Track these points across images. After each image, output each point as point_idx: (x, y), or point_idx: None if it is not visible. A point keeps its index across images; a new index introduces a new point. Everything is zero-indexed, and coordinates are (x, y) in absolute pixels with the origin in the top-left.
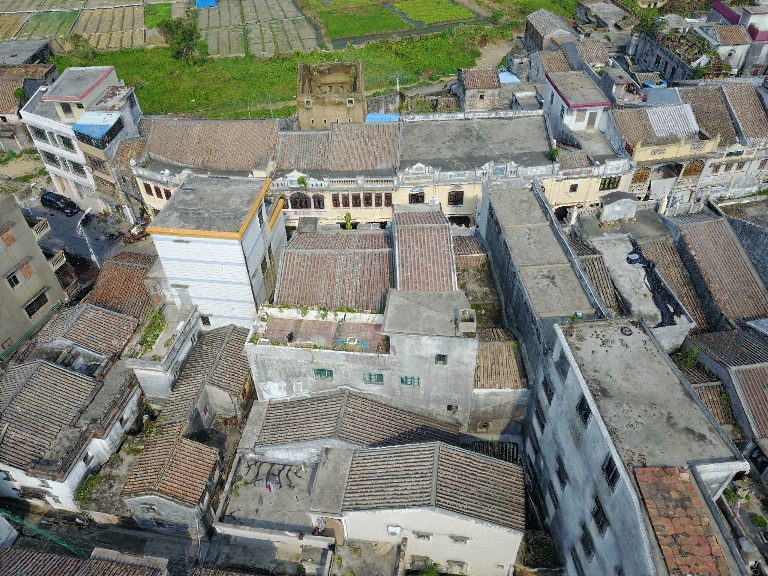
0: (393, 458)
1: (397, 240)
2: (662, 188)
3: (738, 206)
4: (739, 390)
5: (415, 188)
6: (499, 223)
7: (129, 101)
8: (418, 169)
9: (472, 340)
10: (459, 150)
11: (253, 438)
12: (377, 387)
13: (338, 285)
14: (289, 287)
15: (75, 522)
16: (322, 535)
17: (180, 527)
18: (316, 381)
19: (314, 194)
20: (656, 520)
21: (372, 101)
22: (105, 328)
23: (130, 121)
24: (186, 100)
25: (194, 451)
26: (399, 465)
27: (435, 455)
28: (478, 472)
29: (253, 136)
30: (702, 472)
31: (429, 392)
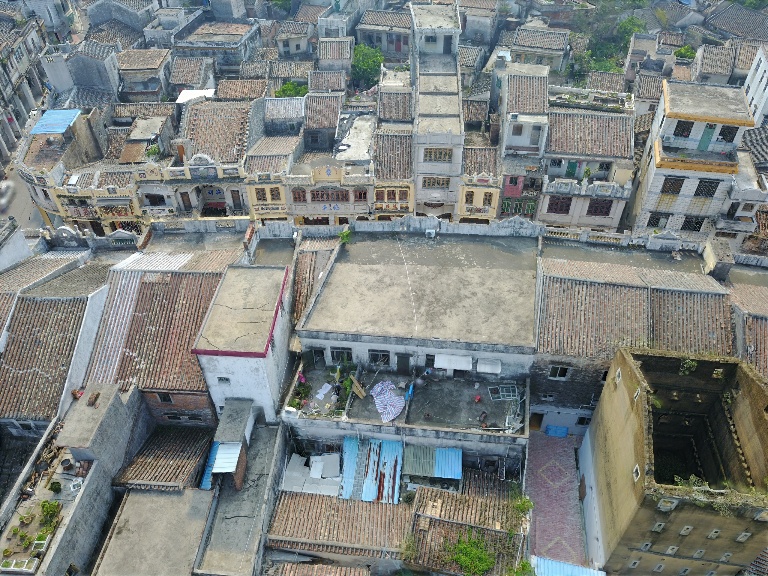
0: None
1: None
2: None
3: None
4: None
5: None
6: None
7: None
8: (517, 223)
9: None
10: (455, 278)
11: None
12: None
13: None
14: None
15: None
16: None
17: None
18: None
19: None
20: None
21: None
22: None
23: None
24: None
25: None
26: None
27: None
28: None
29: None
30: None
31: None
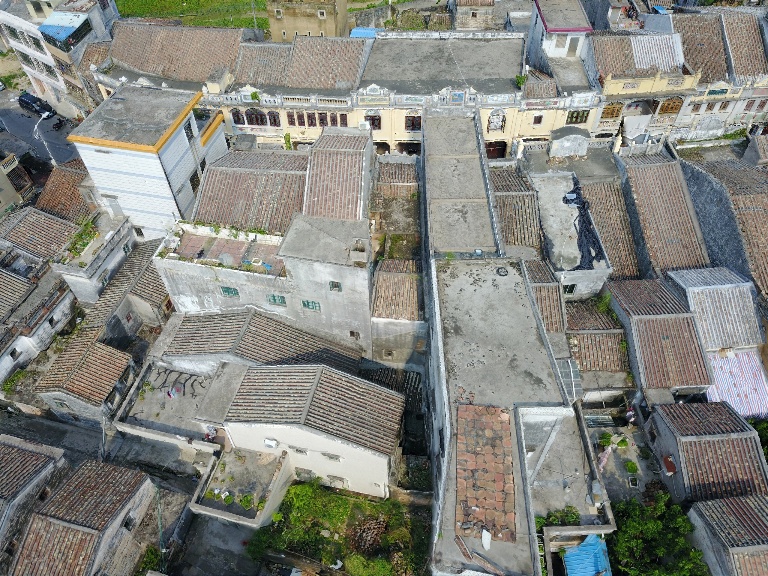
0: (280, 377)
1: (309, 164)
2: (636, 125)
3: (699, 149)
4: (636, 339)
5: (370, 110)
6: (425, 152)
7: (101, 2)
8: (373, 90)
9: (361, 269)
10: (425, 72)
11: (164, 347)
12: (281, 308)
13: (255, 206)
14: (208, 204)
15: (7, 410)
16: (211, 441)
17: (94, 423)
18: (224, 298)
19: (269, 111)
20: (461, 455)
21: (361, 14)
22: (46, 232)
23: (100, 24)
24: (177, 3)
25: (107, 355)
26: (283, 384)
27: (316, 377)
28: (357, 397)
29: (216, 46)
30: (525, 414)
31: (330, 317)
